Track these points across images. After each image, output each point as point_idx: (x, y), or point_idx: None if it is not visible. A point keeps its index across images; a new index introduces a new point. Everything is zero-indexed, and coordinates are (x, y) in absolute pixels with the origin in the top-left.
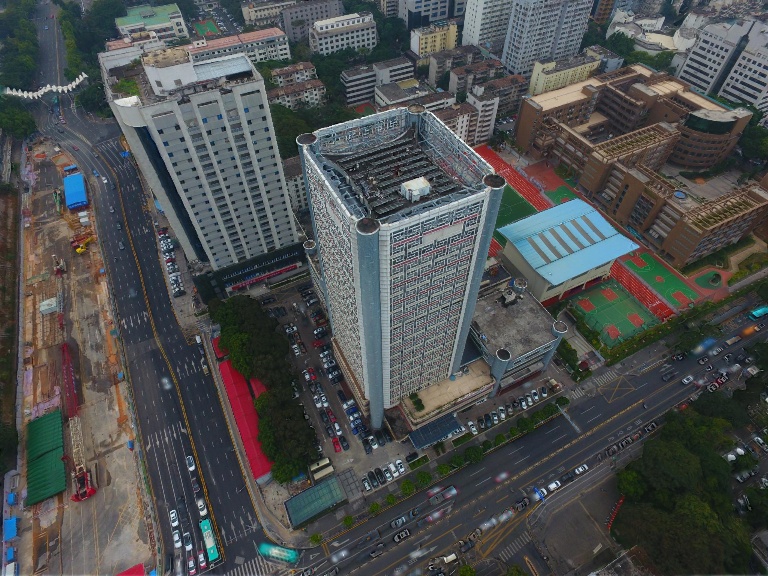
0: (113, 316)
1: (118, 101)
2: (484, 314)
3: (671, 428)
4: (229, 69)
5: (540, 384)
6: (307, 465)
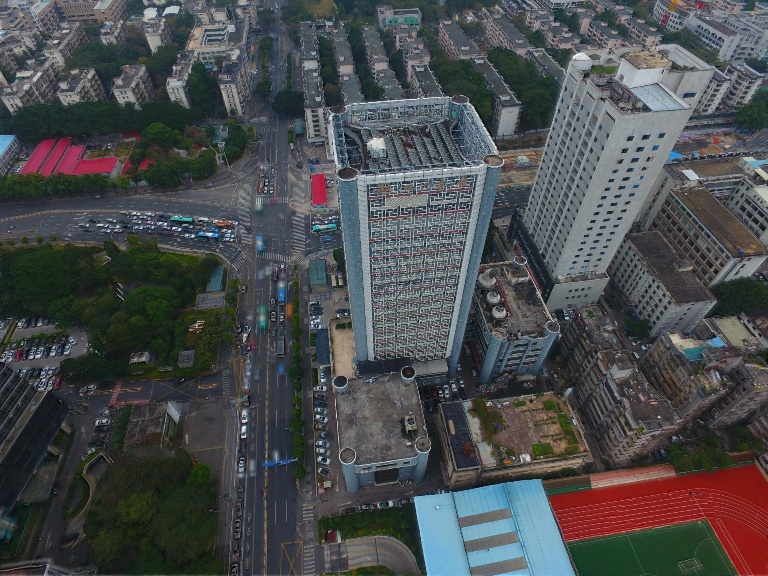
0: (504, 187)
1: (583, 54)
2: (400, 395)
3: (212, 567)
4: (657, 103)
5: (334, 475)
6: (343, 272)
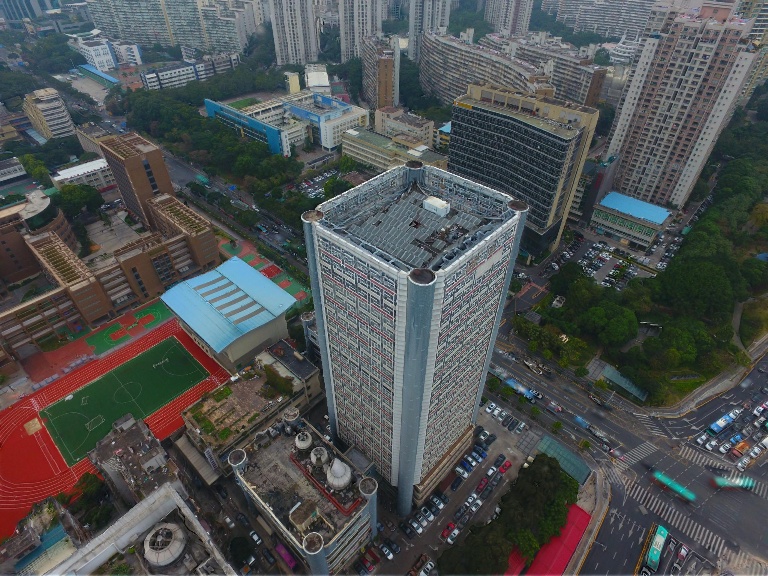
0: None
1: None
2: None
3: None
4: None
5: None
6: None
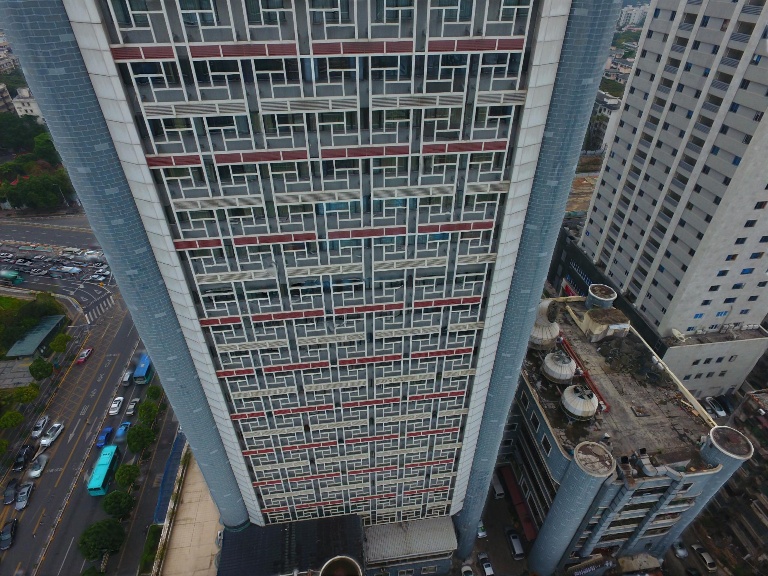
0: None
1: None
2: None
3: None
4: None
5: None
6: None
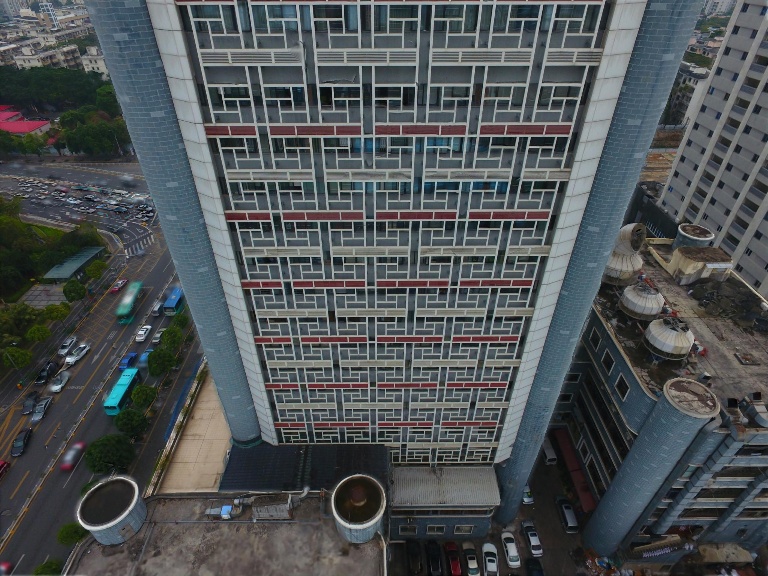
0: None
1: None
2: None
3: None
4: None
5: None
6: None
